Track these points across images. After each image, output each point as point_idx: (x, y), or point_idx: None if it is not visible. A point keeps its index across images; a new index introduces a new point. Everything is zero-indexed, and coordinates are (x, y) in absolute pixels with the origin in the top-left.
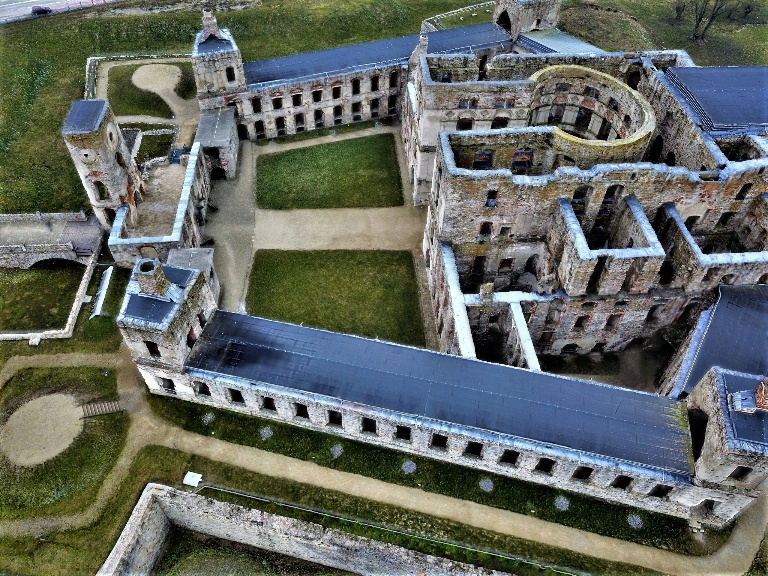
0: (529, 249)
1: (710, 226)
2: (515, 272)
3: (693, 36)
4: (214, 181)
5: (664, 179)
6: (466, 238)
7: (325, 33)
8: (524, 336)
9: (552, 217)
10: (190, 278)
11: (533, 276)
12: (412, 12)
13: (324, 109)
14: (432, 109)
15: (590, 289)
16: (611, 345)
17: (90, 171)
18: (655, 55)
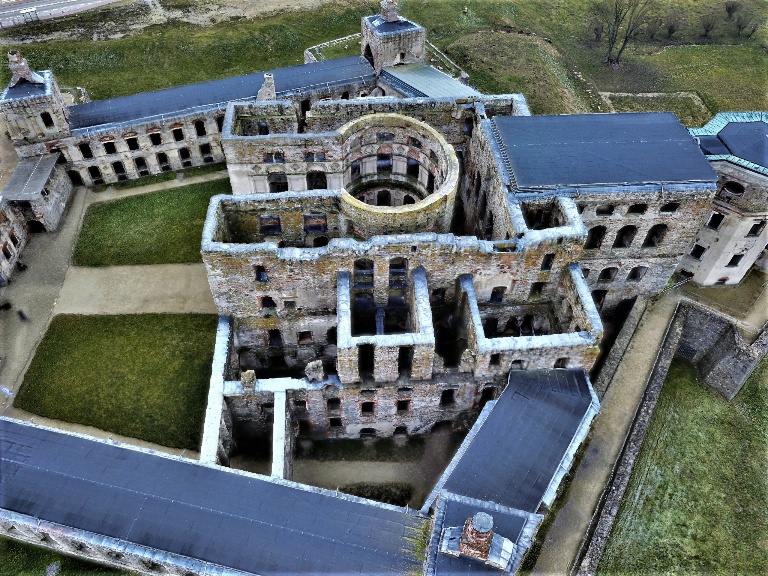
0: (324, 322)
1: (522, 296)
2: (318, 344)
3: (607, 59)
4: (33, 234)
5: (450, 251)
6: (248, 312)
7: (205, 63)
8: (277, 434)
9: (336, 291)
10: None
11: None
12: (305, 38)
13: (167, 152)
14: (235, 163)
15: (367, 375)
16: (414, 428)
17: None
18: (489, 100)
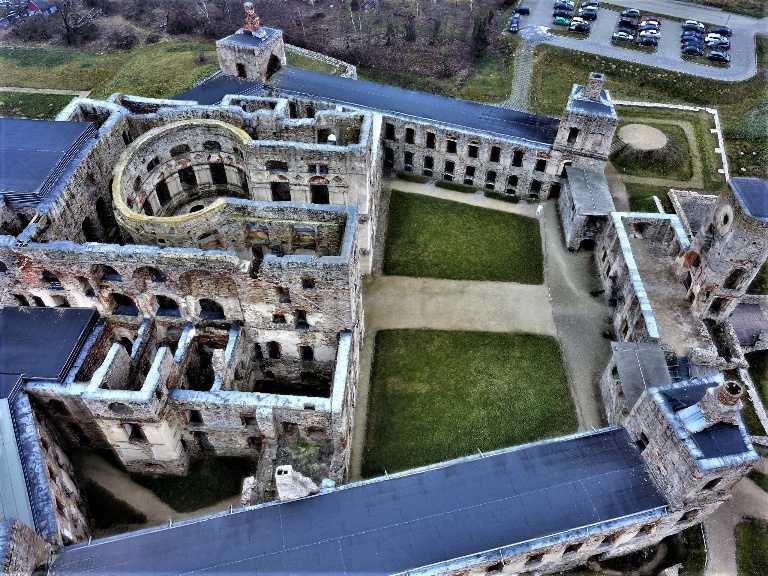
0: None
1: None
2: None
3: None
4: None
5: None
6: None
7: None
8: None
9: None
10: None
11: None
12: None
13: None
14: None
15: None
16: None
17: None
18: None
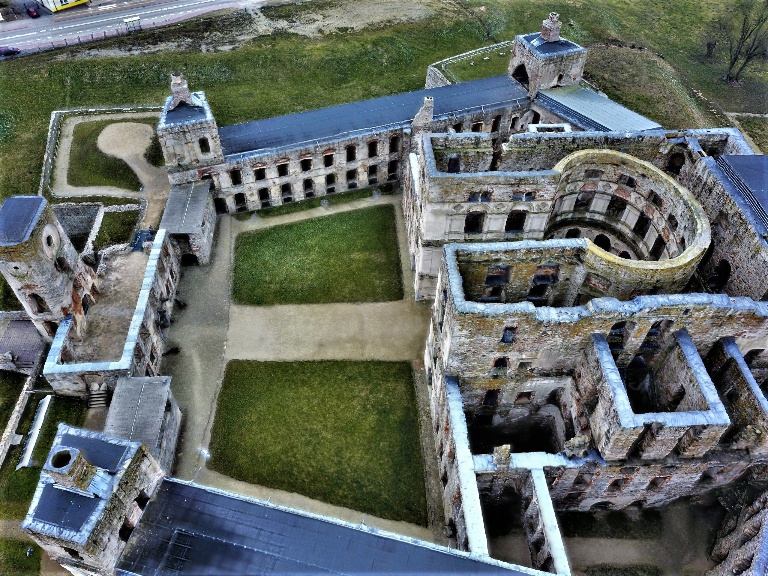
0: (553, 382)
1: None
2: (535, 404)
3: (726, 77)
4: (185, 267)
5: (724, 314)
6: (476, 372)
7: (321, 77)
8: (549, 521)
9: (583, 352)
10: (124, 457)
11: (556, 408)
12: (418, 52)
13: (314, 178)
14: (437, 202)
15: (631, 450)
16: (652, 501)
17: (22, 284)
18: (702, 135)
